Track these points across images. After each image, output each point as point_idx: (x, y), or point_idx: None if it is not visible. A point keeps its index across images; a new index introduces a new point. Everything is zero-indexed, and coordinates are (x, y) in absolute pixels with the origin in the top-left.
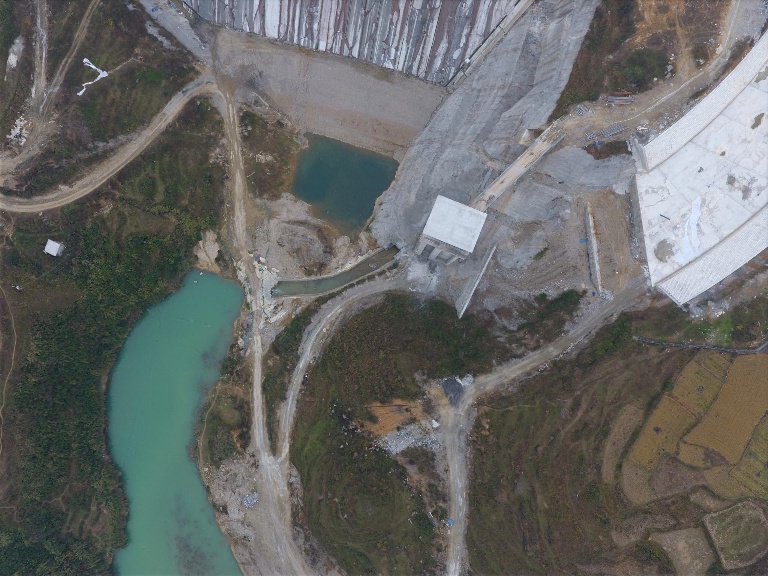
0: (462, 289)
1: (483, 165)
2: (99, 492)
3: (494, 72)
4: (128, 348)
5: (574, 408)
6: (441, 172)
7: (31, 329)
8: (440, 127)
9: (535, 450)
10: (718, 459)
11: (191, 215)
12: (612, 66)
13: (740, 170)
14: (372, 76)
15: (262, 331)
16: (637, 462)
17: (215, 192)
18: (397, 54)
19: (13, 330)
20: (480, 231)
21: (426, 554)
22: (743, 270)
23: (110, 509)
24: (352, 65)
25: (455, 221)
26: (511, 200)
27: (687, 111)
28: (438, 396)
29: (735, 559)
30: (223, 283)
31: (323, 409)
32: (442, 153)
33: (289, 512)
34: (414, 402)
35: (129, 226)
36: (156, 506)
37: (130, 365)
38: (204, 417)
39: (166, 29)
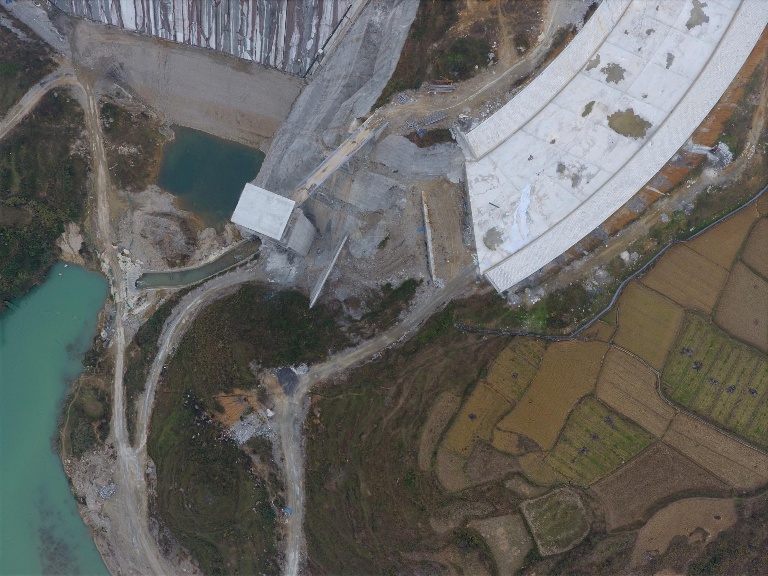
0: (317, 279)
1: (319, 154)
2: None
3: (341, 62)
4: None
5: (396, 396)
6: (287, 162)
7: None
8: (292, 118)
9: (359, 438)
10: (532, 445)
11: (50, 207)
12: (436, 54)
13: (570, 158)
14: (230, 67)
15: (125, 323)
16: (452, 449)
17: (76, 184)
18: (253, 45)
19: None
20: (288, 219)
21: (269, 543)
22: (563, 257)
23: None
24: (210, 56)
25: (263, 209)
26: (352, 190)
27: (510, 99)
28: (272, 385)
29: (552, 545)
30: (88, 275)
31: (178, 400)
32: (291, 143)
33: (146, 503)
34: None
35: None
36: (21, 498)
37: None
38: (67, 409)
39: (21, 21)
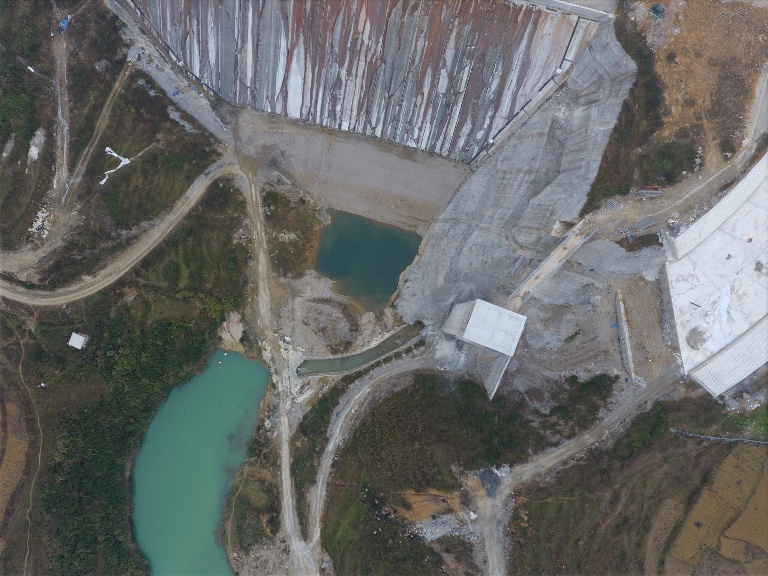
0: (491, 368)
1: (514, 254)
2: None
3: (519, 155)
4: (152, 432)
5: (614, 502)
6: (469, 256)
7: (57, 427)
8: (466, 208)
9: (576, 544)
10: (759, 552)
11: (215, 298)
12: (641, 159)
13: (767, 256)
14: (395, 155)
15: (289, 412)
16: (679, 558)
17: (239, 273)
18: (420, 134)
19: (39, 429)
20: None
21: None
22: None
23: None
24: (375, 144)
25: (495, 325)
26: None
27: (716, 203)
28: (475, 487)
29: None
30: (248, 363)
31: (355, 494)
32: (469, 235)
33: None
34: (451, 494)
35: (153, 313)
36: None
37: (154, 449)
38: (232, 501)
39: (187, 113)
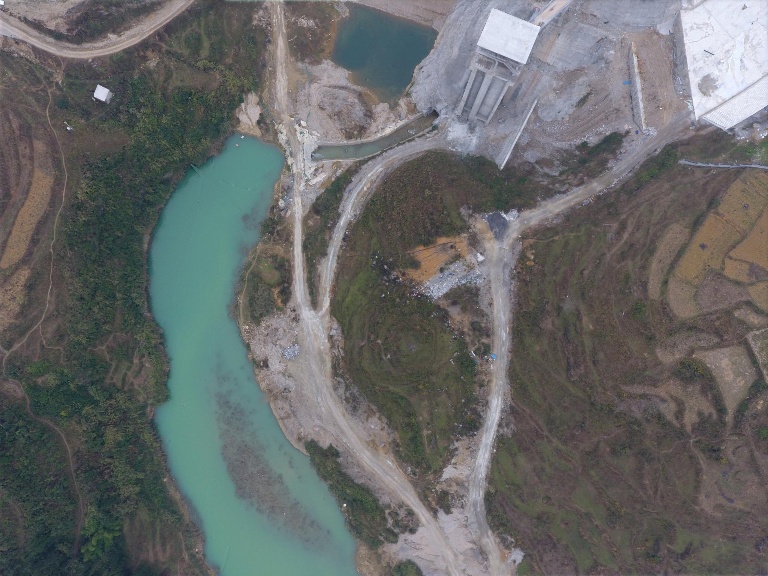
0: (502, 146)
1: (529, 6)
2: (142, 344)
3: None
4: (170, 210)
5: (620, 231)
6: None
7: (81, 168)
8: None
9: (581, 274)
10: (763, 274)
11: (235, 74)
12: None
13: None
14: None
15: (302, 193)
16: (683, 277)
17: (258, 54)
18: None
19: (64, 168)
20: (533, 43)
21: (468, 392)
22: None
23: (152, 362)
24: None
25: (509, 33)
26: (555, 45)
27: None
28: (483, 230)
29: None
30: (264, 147)
31: (364, 261)
32: (485, 6)
33: (329, 364)
34: (459, 236)
35: (175, 80)
36: (196, 364)
37: (171, 227)
38: (245, 276)
39: None
